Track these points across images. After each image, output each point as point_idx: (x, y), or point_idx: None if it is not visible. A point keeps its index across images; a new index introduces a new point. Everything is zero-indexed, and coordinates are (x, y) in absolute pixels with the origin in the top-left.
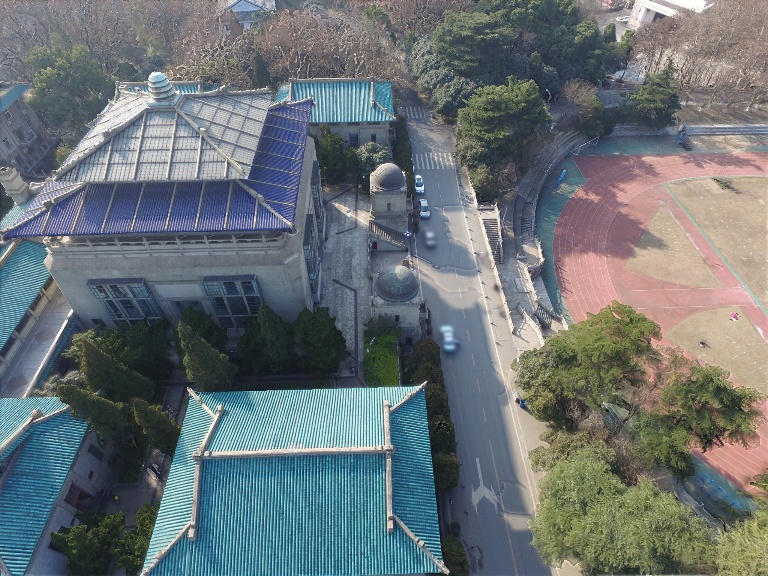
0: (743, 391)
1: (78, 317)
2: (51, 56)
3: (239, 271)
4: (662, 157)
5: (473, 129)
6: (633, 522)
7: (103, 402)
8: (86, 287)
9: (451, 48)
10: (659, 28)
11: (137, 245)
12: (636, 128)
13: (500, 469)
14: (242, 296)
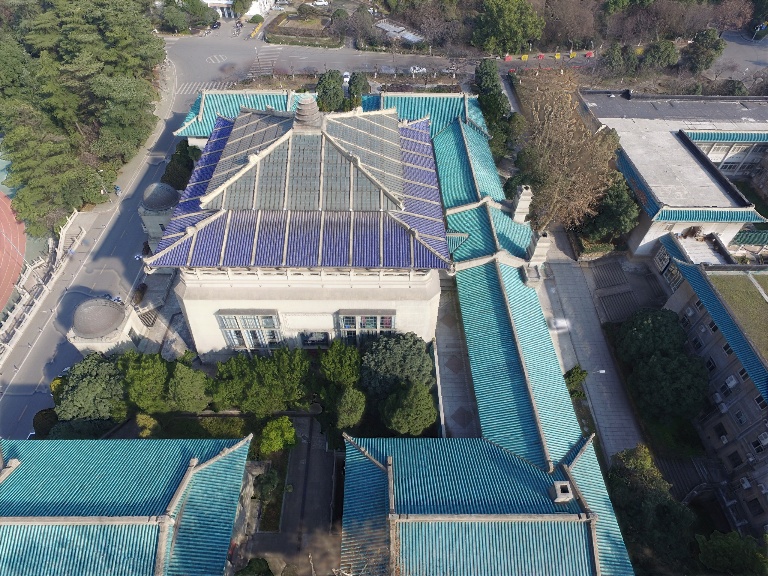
0: (6, 109)
1: None
2: None
3: None
4: None
5: None
6: (116, 81)
7: None
8: None
9: None
10: None
11: None
12: None
13: (156, 169)
14: None
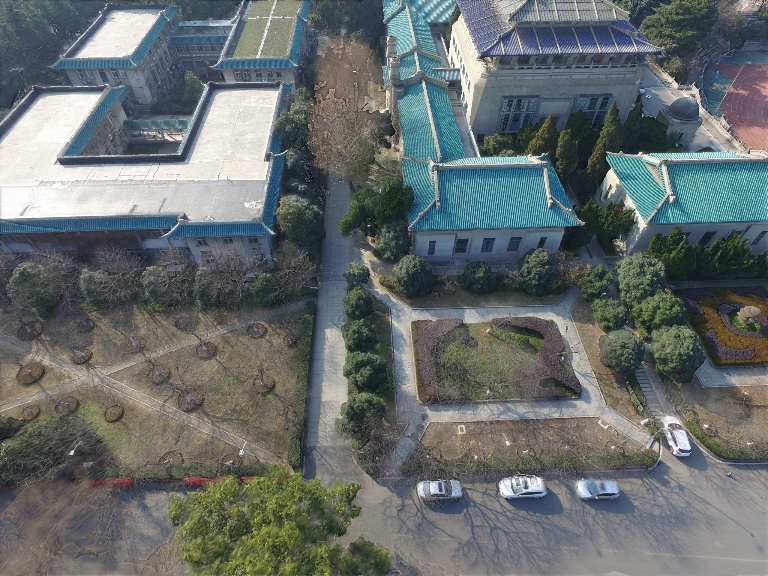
0: None
1: None
2: None
3: (603, 90)
4: None
5: (665, 30)
6: None
7: (577, 146)
8: (496, 103)
9: None
10: None
11: (545, 69)
12: (761, 44)
13: None
14: (596, 111)
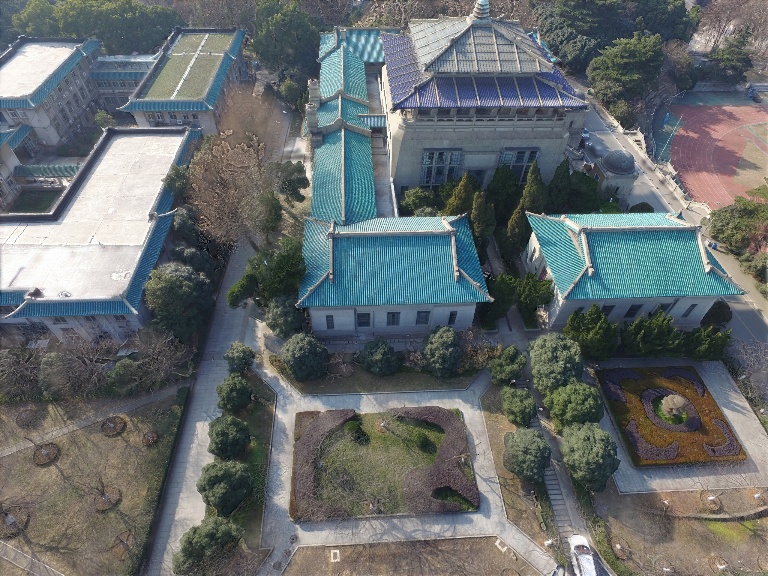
0: None
1: (394, 184)
2: (273, 5)
3: (530, 143)
4: (738, 107)
5: (611, 73)
6: None
7: None
8: (417, 156)
9: (573, 12)
10: (727, 3)
11: (467, 121)
12: (713, 85)
13: None
14: (524, 165)
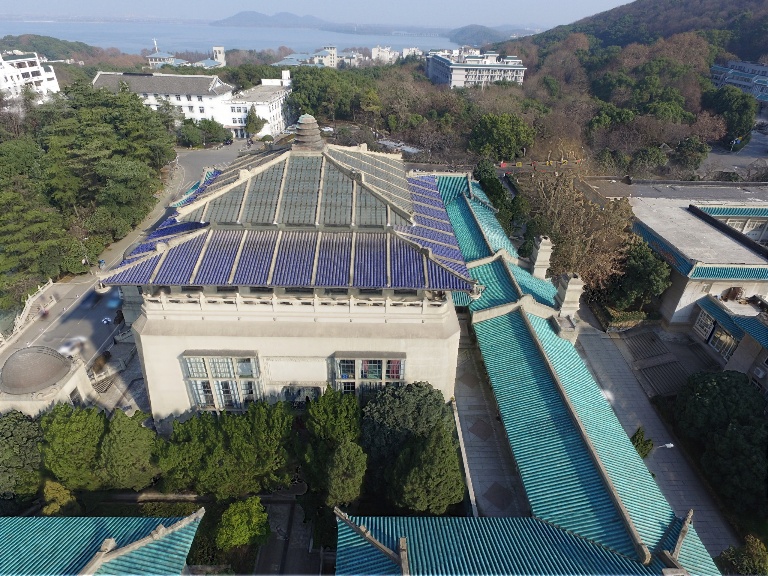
0: None
1: None
2: None
3: None
4: None
5: None
6: None
7: None
8: None
9: None
10: None
11: None
12: None
13: None
14: None
